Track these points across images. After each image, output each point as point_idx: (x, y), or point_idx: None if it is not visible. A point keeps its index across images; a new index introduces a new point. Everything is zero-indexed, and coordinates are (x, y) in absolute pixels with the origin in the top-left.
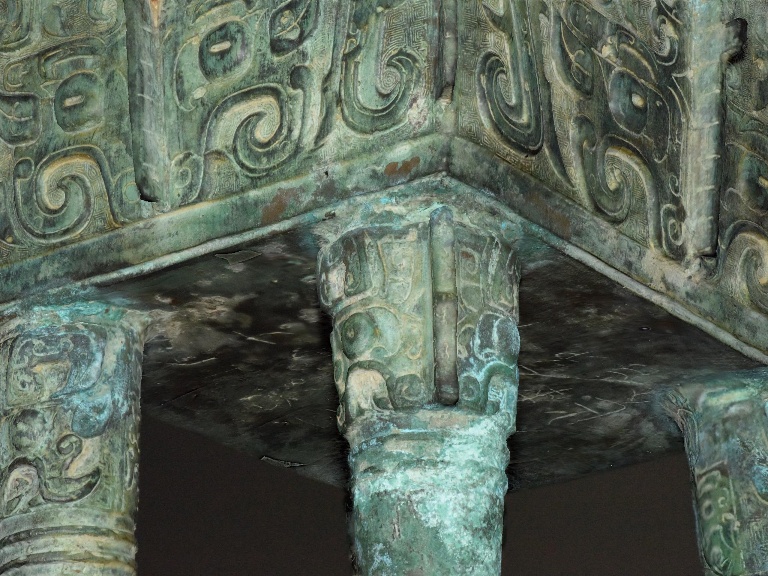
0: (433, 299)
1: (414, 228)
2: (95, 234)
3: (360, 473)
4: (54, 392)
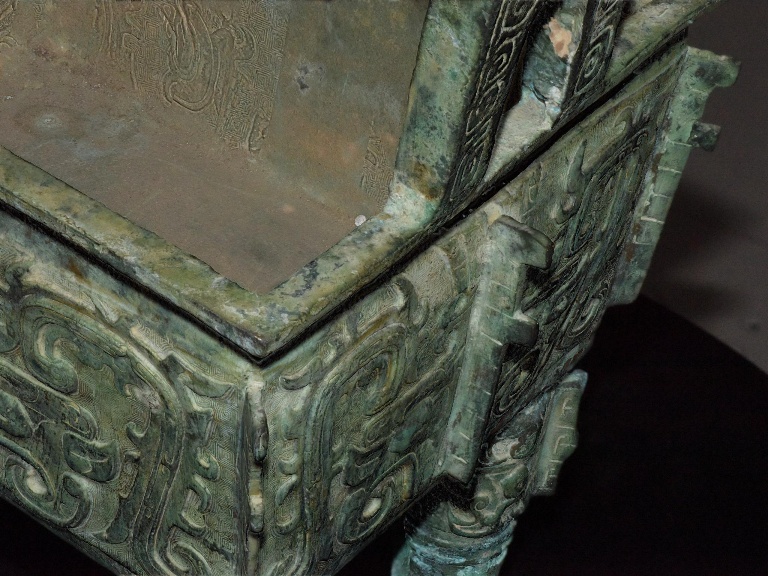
0: None
1: None
2: None
3: None
4: None
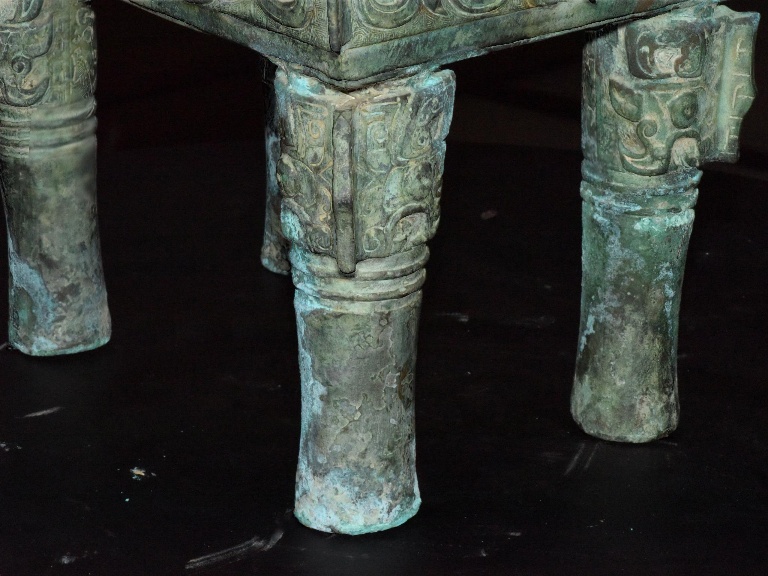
0: (753, 92)
1: (724, 22)
2: (511, 11)
3: (662, 211)
4: (433, 141)
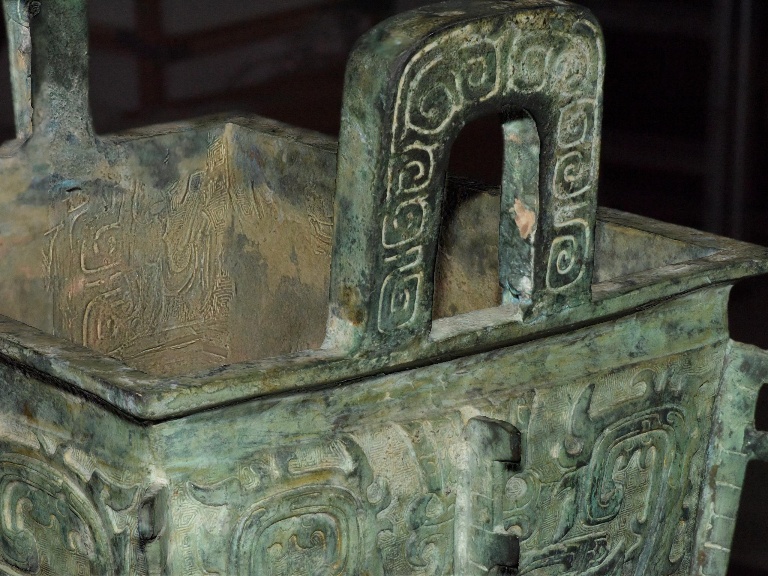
0: None
1: None
2: None
3: None
4: None
